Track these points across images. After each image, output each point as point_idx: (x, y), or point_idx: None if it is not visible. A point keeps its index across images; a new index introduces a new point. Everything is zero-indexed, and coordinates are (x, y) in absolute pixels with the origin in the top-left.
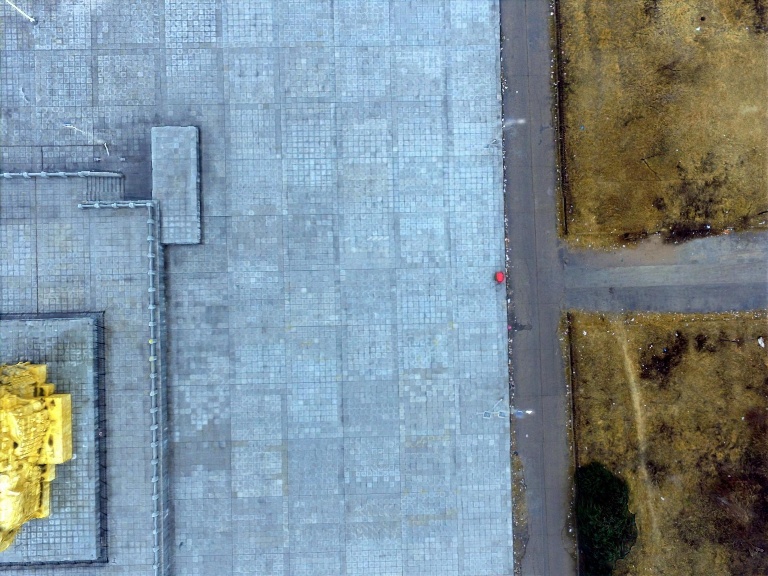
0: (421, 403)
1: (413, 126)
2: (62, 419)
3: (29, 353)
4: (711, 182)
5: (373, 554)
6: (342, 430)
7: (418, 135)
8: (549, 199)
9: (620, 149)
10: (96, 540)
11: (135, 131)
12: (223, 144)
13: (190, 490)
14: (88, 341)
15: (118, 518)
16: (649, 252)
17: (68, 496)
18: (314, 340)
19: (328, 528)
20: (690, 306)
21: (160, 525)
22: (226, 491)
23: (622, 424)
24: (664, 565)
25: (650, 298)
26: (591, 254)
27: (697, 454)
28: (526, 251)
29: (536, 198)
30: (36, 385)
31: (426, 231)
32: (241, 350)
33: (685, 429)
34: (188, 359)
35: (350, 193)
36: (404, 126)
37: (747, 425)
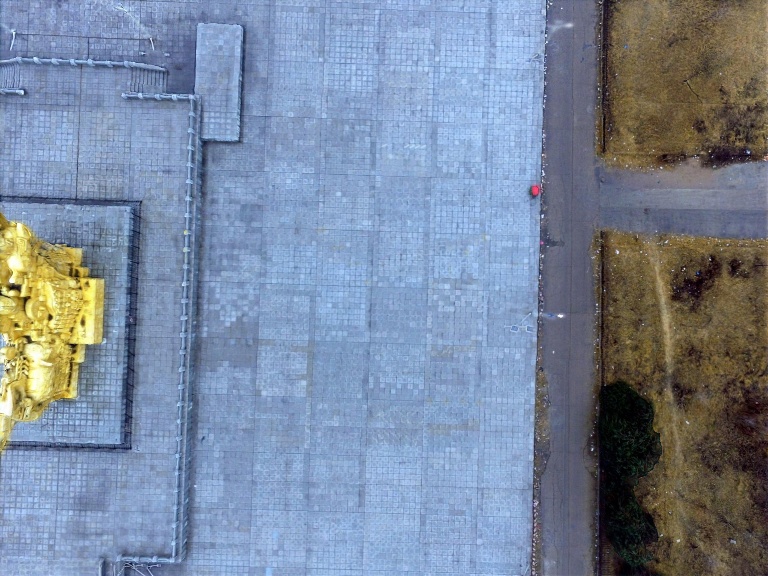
0: (449, 313)
1: (456, 37)
2: (95, 300)
3: (66, 236)
4: (753, 107)
5: (393, 460)
6: (369, 335)
7: (461, 46)
8: (588, 117)
9: (663, 70)
10: (121, 425)
11: (181, 27)
12: (267, 45)
13: (215, 385)
14: (124, 228)
15: (143, 406)
16: (686, 175)
17: (96, 380)
18: (346, 244)
19: (350, 432)
20: (725, 231)
21: (184, 416)
22: (250, 388)
23: (650, 345)
24: (686, 489)
25: (685, 221)
26: (628, 174)
27: (725, 380)
28: (562, 168)
29: (575, 115)
30: (72, 265)
31: (463, 142)
32: (273, 250)
33: (714, 354)
34: (220, 255)
35: (390, 100)
36: (447, 36)
37: None
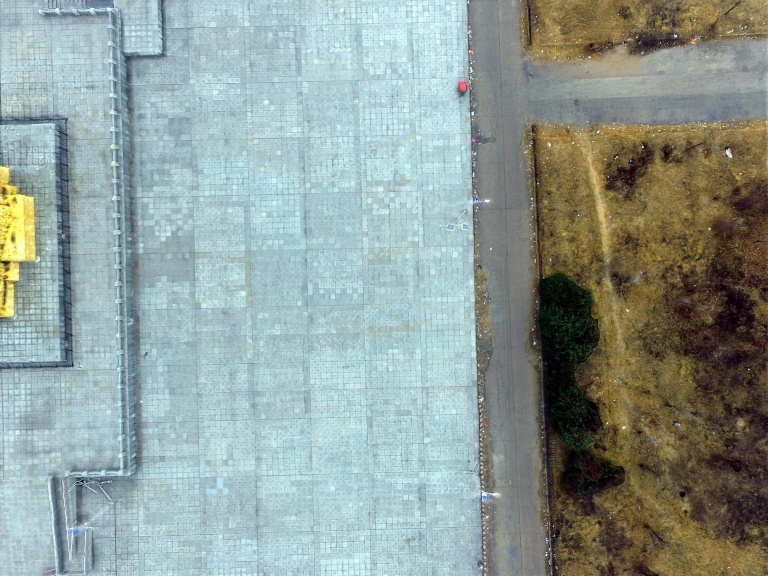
0: (384, 215)
1: None
2: (24, 216)
3: None
4: None
5: (336, 365)
6: (305, 242)
7: None
8: (513, 10)
9: None
10: (60, 342)
11: None
12: None
13: (154, 301)
14: (50, 145)
15: (83, 324)
16: (615, 63)
17: (32, 298)
18: (277, 152)
19: (292, 339)
20: (657, 117)
21: (124, 330)
22: (190, 302)
23: (587, 235)
24: (629, 376)
25: (616, 110)
26: (556, 66)
27: (663, 265)
28: (490, 63)
29: (500, 9)
30: None
31: (389, 42)
32: (204, 162)
33: (651, 240)
34: (151, 171)
35: (312, 4)
36: None
37: (714, 236)
